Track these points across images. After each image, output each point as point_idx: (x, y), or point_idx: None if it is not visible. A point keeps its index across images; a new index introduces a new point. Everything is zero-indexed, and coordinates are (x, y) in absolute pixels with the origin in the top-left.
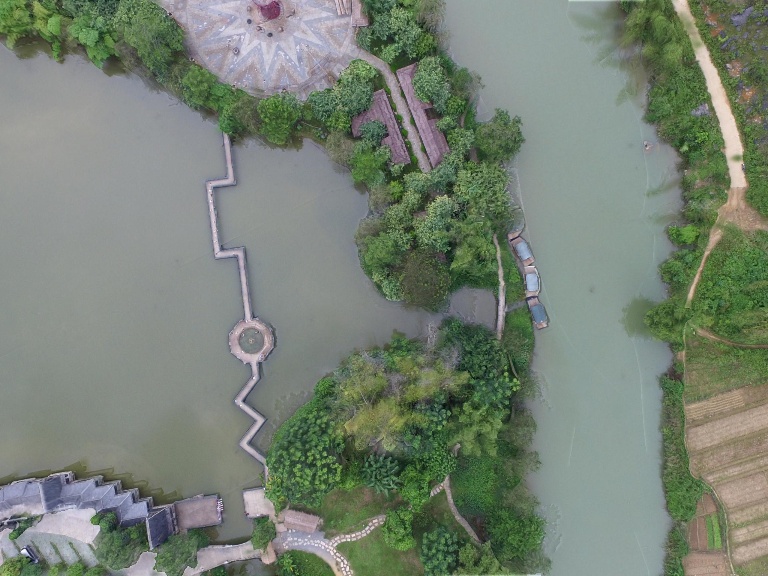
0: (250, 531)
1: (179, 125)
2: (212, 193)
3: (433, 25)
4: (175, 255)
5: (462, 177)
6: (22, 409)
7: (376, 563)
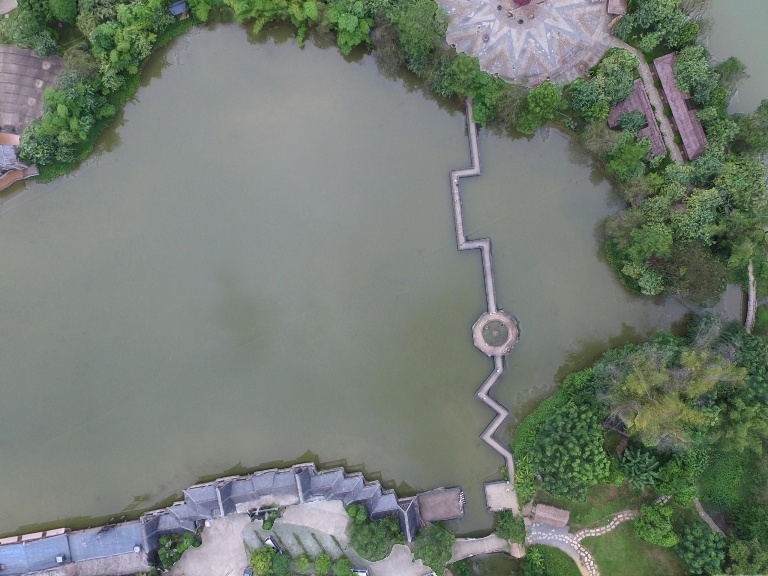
0: (489, 524)
1: (420, 113)
2: (458, 183)
3: (700, 13)
4: (418, 246)
5: (728, 170)
6: (262, 399)
7: (620, 558)
